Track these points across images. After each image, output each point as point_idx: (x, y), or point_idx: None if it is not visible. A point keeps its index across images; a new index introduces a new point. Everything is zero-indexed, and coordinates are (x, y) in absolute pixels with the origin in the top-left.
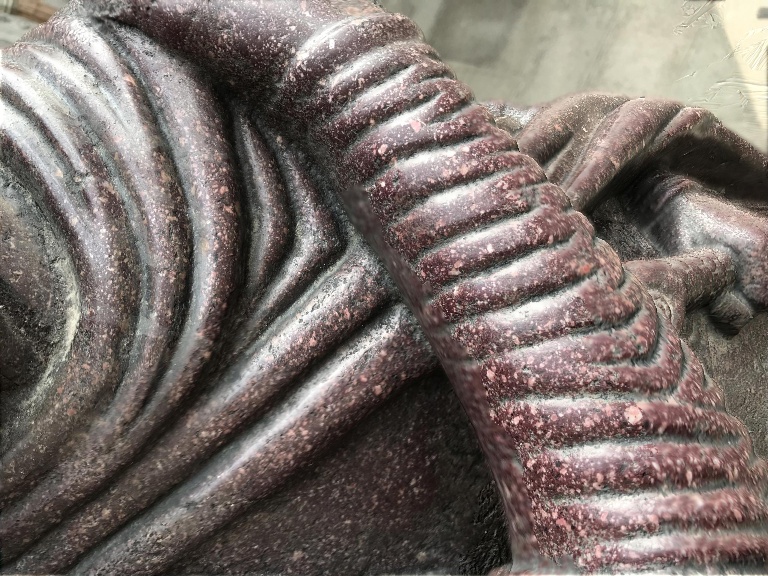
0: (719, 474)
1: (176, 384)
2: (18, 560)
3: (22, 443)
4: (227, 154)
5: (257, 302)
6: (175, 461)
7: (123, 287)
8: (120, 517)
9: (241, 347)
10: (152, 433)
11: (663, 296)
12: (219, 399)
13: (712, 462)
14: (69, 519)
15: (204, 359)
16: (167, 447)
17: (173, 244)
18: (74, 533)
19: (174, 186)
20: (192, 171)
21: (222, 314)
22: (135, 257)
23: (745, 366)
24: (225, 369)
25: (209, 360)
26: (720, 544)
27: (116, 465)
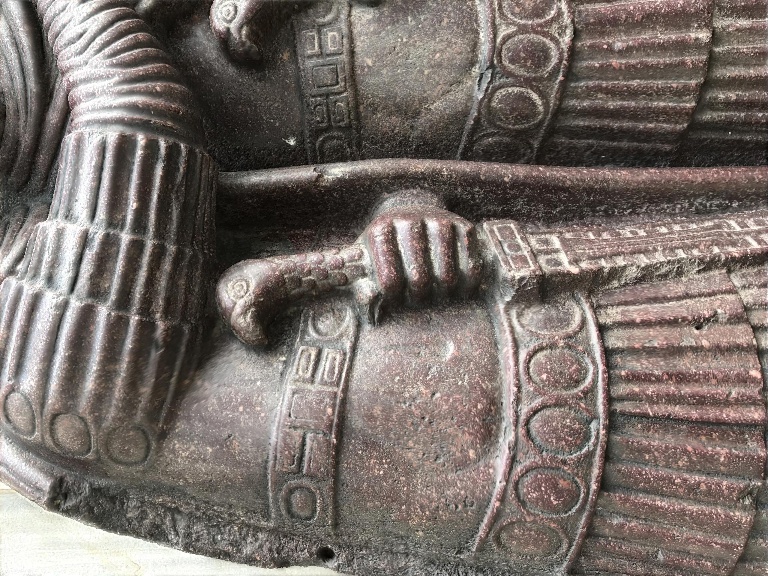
0: (92, 94)
1: (30, 104)
2: (31, 176)
3: (5, 134)
4: (17, 5)
5: (51, 64)
6: (49, 134)
7: (4, 71)
8: (47, 157)
9: (52, 85)
10: (34, 124)
11: (236, 2)
12: (50, 107)
13: (90, 90)
14: (34, 160)
15: (34, 92)
16: (45, 129)
17: (9, 50)
18: (38, 165)
19: (5, 26)
20: (8, 17)
21: (33, 73)
22: (5, 58)
23: (395, 23)
24: (50, 95)
25: (37, 92)
26: (82, 119)
27: (30, 137)
